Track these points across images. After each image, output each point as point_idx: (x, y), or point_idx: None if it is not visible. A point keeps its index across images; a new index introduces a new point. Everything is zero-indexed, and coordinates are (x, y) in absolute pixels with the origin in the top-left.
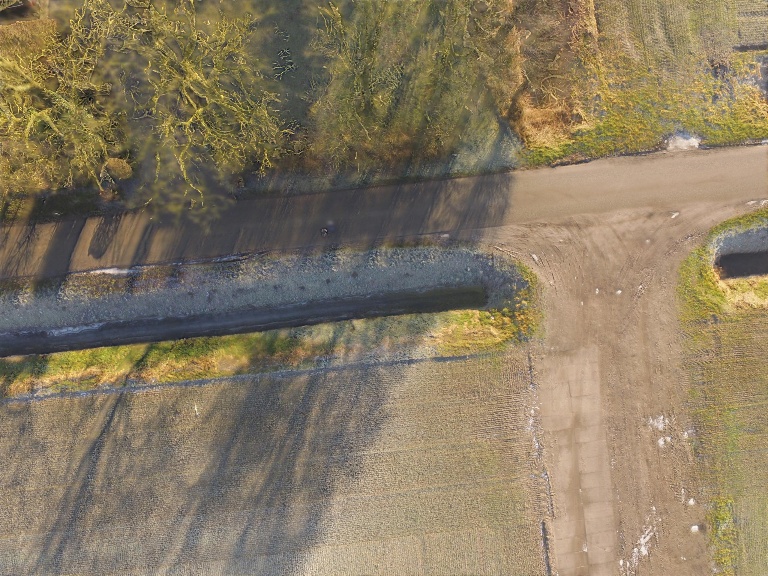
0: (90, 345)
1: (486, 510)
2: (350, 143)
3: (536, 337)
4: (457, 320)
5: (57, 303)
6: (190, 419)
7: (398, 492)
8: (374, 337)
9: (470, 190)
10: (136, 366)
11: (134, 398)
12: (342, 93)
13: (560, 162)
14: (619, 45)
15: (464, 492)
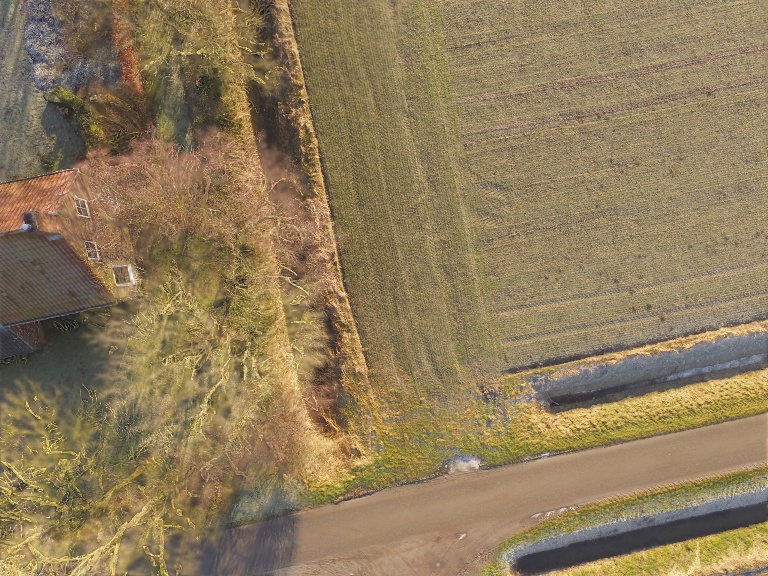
0: None
1: None
2: (127, 507)
3: None
4: None
5: None
6: None
7: None
8: None
9: (255, 536)
10: None
11: None
12: (115, 458)
13: (342, 499)
14: (389, 381)
15: None
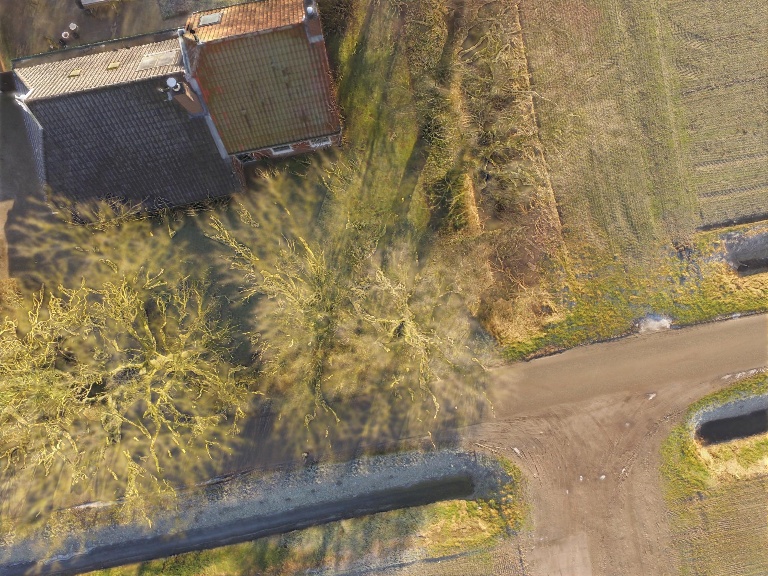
0: (81, 570)
1: None
2: (323, 359)
3: (524, 530)
4: (445, 514)
5: (44, 540)
6: None
7: None
8: (364, 541)
9: (447, 392)
10: None
11: None
12: None
13: (534, 356)
14: (583, 236)
15: None
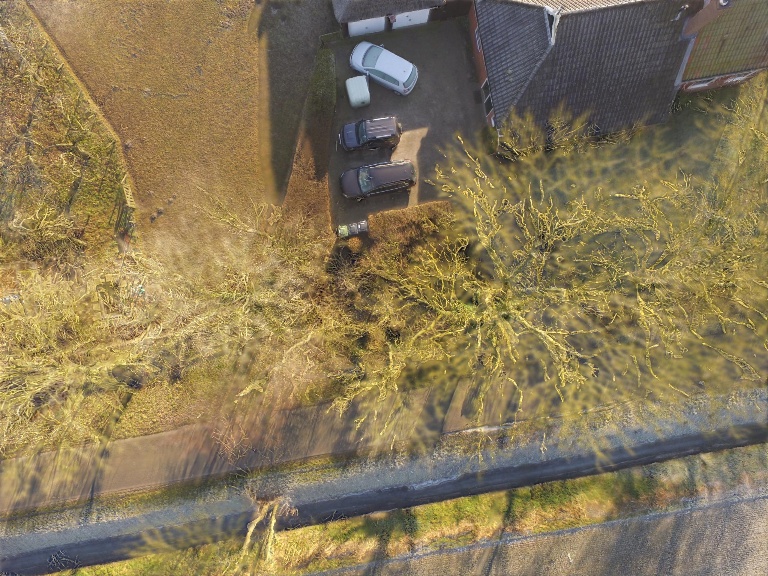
0: (449, 496)
1: None
2: None
3: None
4: None
5: (430, 463)
6: (564, 567)
7: None
8: (731, 473)
9: None
10: (507, 518)
11: (509, 550)
12: None
13: None
14: None
15: None
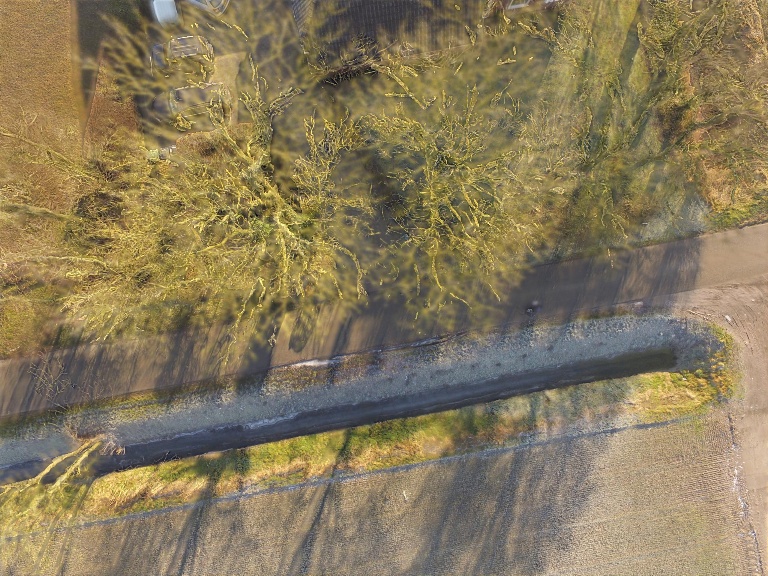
0: (286, 435)
1: (697, 572)
2: (543, 219)
3: (735, 397)
4: (650, 384)
5: (259, 399)
6: (399, 505)
7: (610, 561)
8: (572, 408)
9: (662, 257)
10: (340, 455)
11: (342, 488)
12: (532, 170)
13: (747, 223)
14: None
15: (674, 556)
